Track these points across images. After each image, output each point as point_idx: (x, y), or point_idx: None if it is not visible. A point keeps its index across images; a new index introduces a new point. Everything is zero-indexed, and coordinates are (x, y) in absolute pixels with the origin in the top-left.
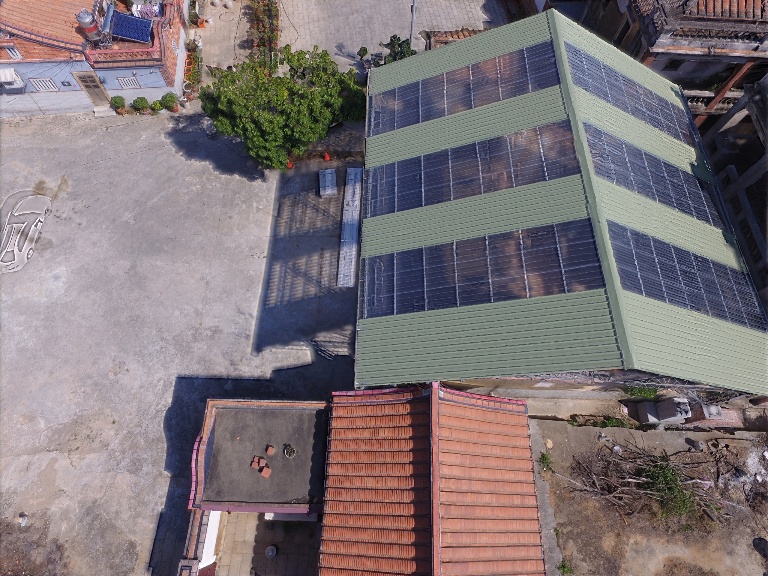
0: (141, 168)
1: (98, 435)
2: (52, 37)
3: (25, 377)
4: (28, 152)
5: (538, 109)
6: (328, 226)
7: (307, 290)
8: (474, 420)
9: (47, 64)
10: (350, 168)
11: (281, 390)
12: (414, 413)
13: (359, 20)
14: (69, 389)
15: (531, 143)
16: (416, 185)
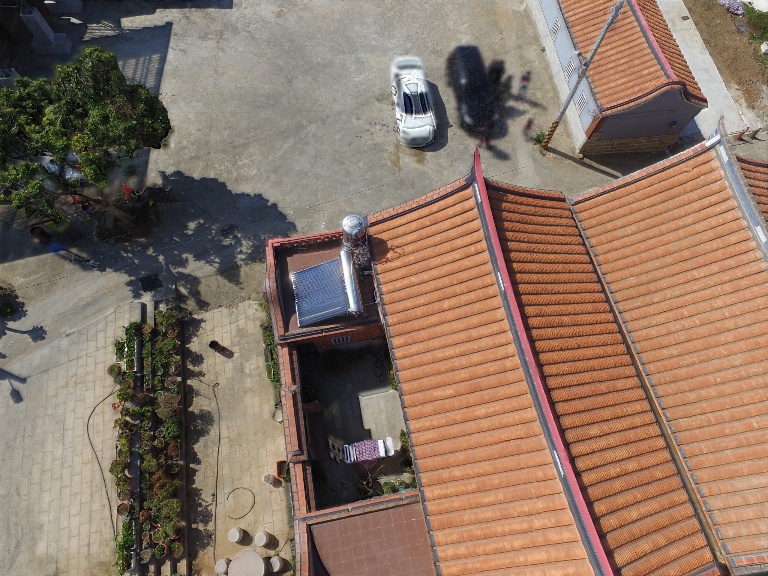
0: (313, 182)
1: None
2: (403, 208)
3: (352, 8)
4: None
5: None
6: None
7: None
8: None
9: None
10: None
11: (147, 3)
12: None
13: None
14: (315, 2)
15: None
16: None
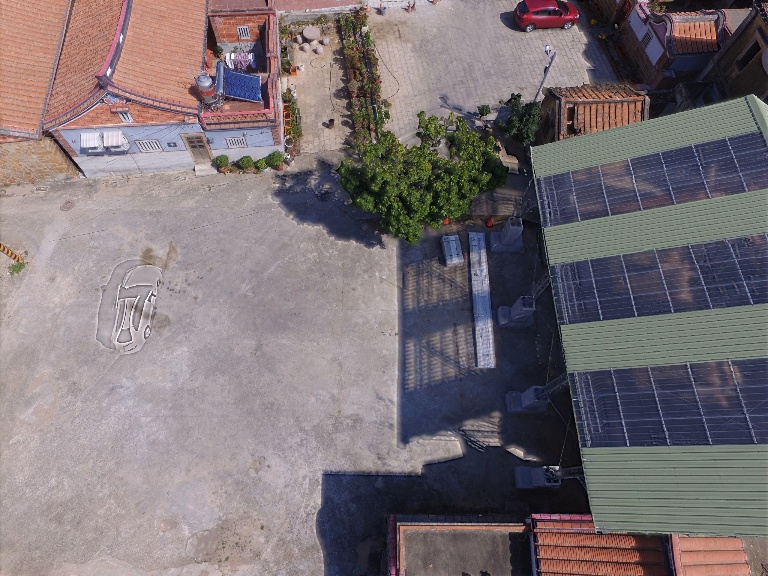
0: (252, 233)
1: (247, 543)
2: (169, 101)
3: (160, 476)
4: (130, 216)
5: (762, 213)
6: (457, 298)
7: (446, 372)
8: (699, 551)
9: (157, 127)
10: (471, 233)
11: (435, 488)
12: (641, 548)
13: (460, 68)
14: (209, 489)
15: (762, 253)
16: (621, 290)
